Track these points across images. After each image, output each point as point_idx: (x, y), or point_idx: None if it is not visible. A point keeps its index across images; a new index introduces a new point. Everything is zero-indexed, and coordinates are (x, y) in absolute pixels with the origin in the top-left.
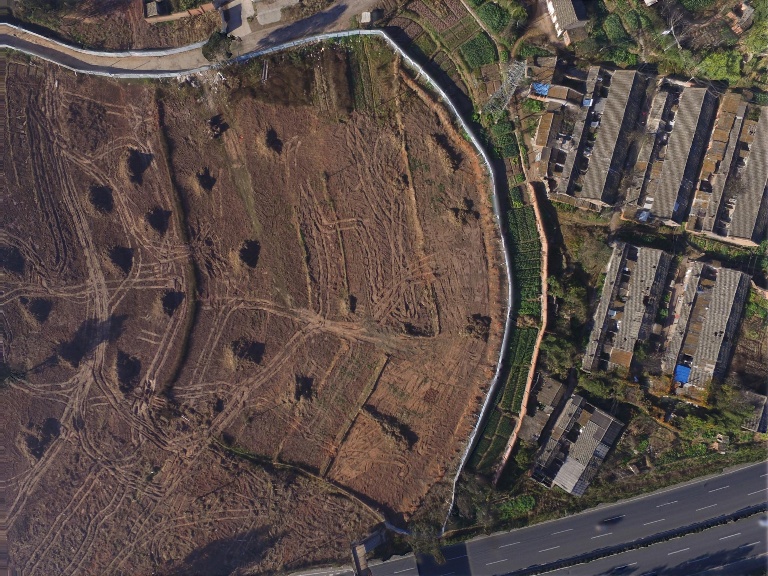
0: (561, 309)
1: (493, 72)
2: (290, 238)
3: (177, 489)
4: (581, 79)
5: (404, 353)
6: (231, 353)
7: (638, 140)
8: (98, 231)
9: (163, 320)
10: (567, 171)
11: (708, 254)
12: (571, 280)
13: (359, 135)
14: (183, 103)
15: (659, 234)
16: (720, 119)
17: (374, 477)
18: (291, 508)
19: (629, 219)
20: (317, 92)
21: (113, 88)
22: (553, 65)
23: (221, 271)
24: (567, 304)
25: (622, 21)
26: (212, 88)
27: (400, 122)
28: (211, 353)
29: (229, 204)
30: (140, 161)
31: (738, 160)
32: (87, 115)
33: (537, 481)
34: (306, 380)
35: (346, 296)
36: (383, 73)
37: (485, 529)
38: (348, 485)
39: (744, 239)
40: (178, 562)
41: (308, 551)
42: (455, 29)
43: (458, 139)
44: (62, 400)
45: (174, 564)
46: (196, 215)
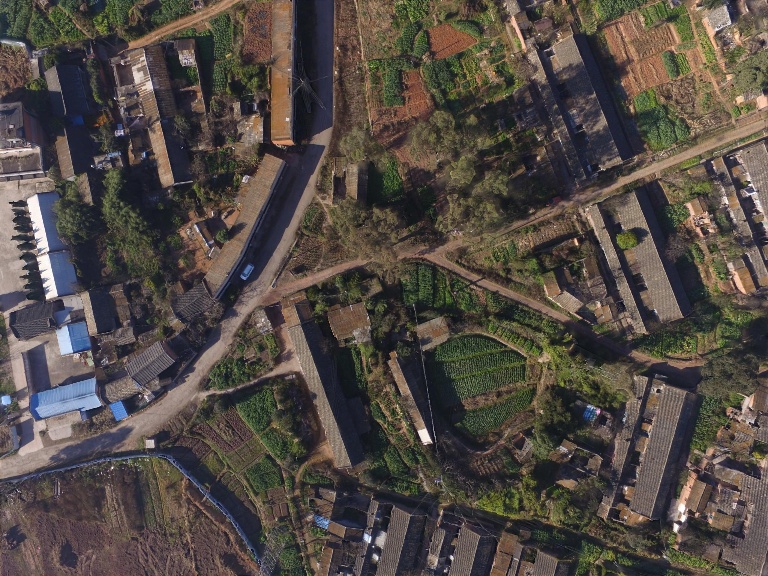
0: None
1: (279, 495)
2: None
3: None
4: (362, 510)
5: None
6: None
7: None
8: None
9: None
10: None
11: None
12: None
13: (151, 552)
14: None
15: None
16: (497, 559)
17: None
18: None
19: None
20: (108, 510)
21: None
22: (332, 500)
23: None
24: None
25: (401, 455)
26: (8, 499)
27: None
28: None
29: None
30: None
31: None
32: None
33: None
34: None
35: None
36: (172, 491)
37: None
38: None
39: None
40: None
41: None
42: (241, 451)
43: (246, 560)
44: None
45: None
46: None
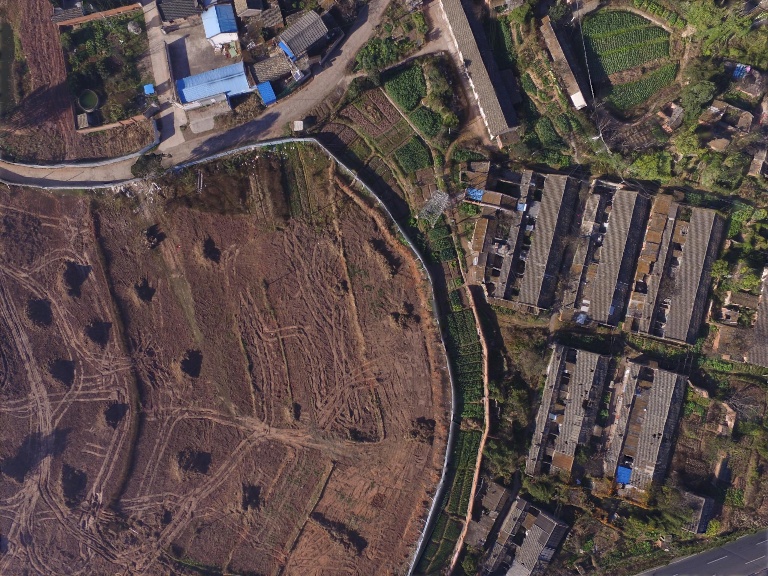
0: (503, 412)
1: (428, 176)
2: (232, 347)
3: None
4: (515, 183)
5: (350, 459)
6: (176, 465)
7: (573, 244)
8: (38, 344)
9: (107, 432)
10: (504, 276)
11: (646, 354)
12: (512, 383)
13: (297, 242)
14: (119, 213)
15: (597, 334)
16: (652, 220)
17: None
18: None
19: (567, 322)
20: (253, 200)
21: (47, 200)
22: (486, 170)
23: (164, 381)
24: (509, 406)
25: (553, 124)
26: (147, 198)
27: (337, 228)
28: (157, 464)
29: (169, 314)
30: (78, 273)
31: (672, 259)
32: (22, 228)
33: None
34: (253, 489)
35: (290, 404)
36: (319, 179)
37: None
38: None
39: (679, 341)
40: None
41: None
42: (389, 134)
43: (396, 244)
44: (9, 516)
45: None
46: (136, 326)
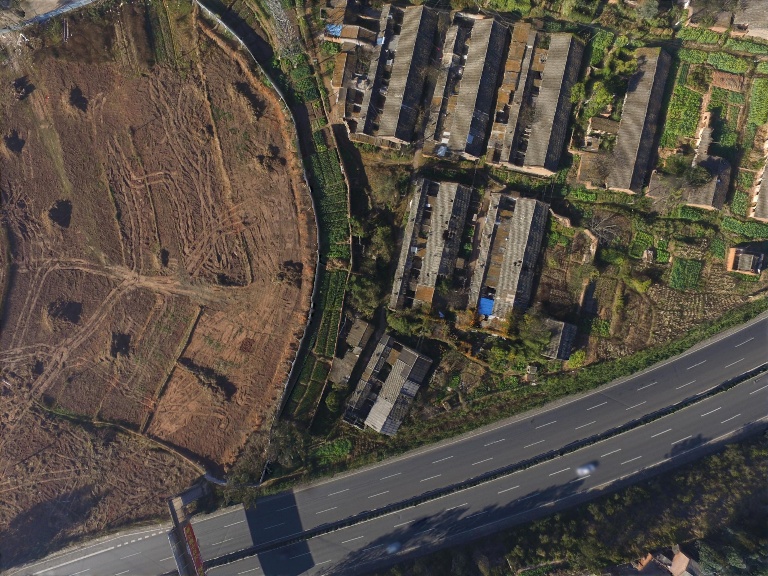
0: (369, 250)
1: (290, 17)
2: (101, 196)
3: (0, 454)
4: (375, 18)
5: (218, 304)
6: (46, 314)
7: (431, 75)
8: None
9: None
10: (364, 110)
11: (509, 186)
12: (377, 220)
13: (162, 88)
14: None
15: (461, 169)
16: (511, 49)
17: (194, 430)
18: (113, 466)
19: (428, 155)
20: (118, 47)
21: None
22: (344, 5)
23: (35, 233)
24: (374, 245)
25: None
26: (16, 50)
27: (201, 72)
28: (29, 316)
29: (39, 165)
30: None
31: (535, 90)
32: None
33: (350, 423)
34: (123, 337)
35: (158, 250)
36: (183, 25)
37: (303, 475)
38: (168, 440)
39: (537, 167)
40: (4, 527)
41: (131, 508)
42: None
43: (259, 86)
44: None
45: (0, 530)
46: (7, 178)
